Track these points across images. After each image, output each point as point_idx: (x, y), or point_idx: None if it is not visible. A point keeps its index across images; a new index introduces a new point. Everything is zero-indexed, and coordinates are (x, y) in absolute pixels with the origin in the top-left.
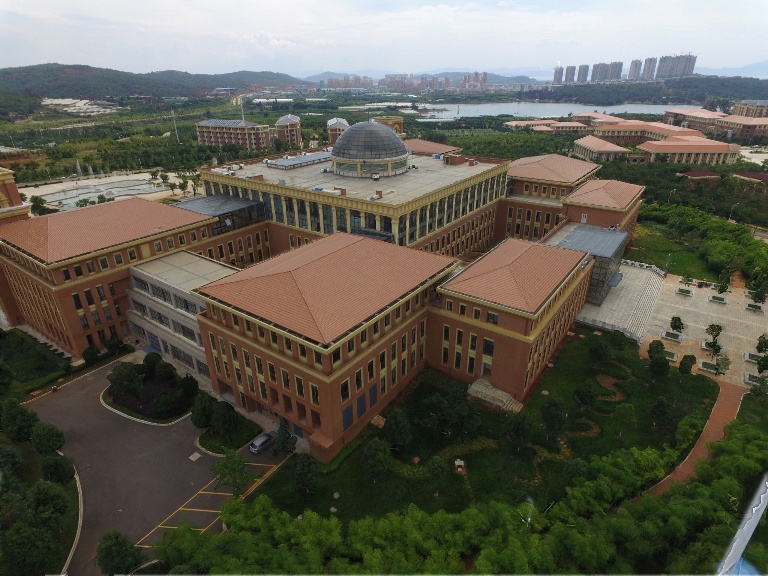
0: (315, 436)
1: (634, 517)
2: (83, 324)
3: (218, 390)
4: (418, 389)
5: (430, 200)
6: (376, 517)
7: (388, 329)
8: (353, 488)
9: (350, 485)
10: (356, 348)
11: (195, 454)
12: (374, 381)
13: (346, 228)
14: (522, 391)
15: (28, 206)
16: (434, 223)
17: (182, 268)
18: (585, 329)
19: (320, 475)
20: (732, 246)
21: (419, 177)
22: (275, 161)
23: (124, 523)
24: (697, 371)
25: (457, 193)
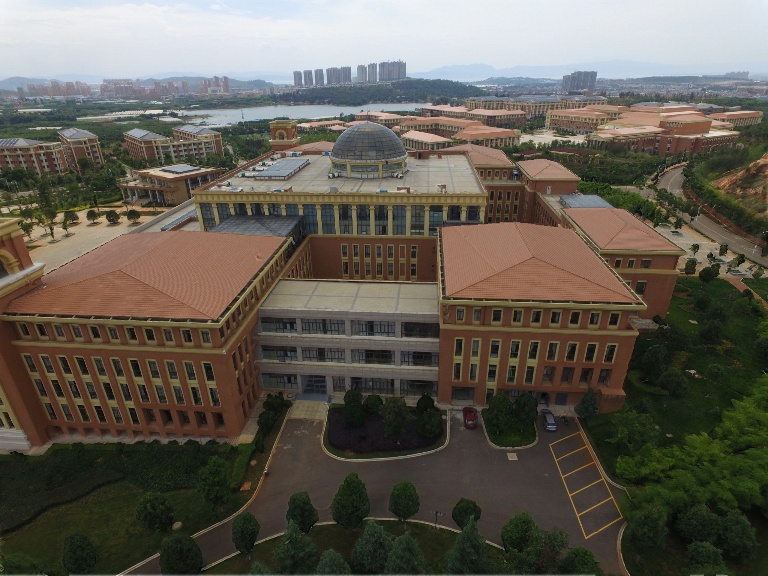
0: (606, 391)
1: None
2: None
3: (449, 399)
4: None
5: None
6: (700, 425)
7: None
8: (660, 416)
9: (656, 416)
10: None
11: (509, 455)
12: None
13: (422, 225)
14: None
15: (43, 266)
16: None
17: (318, 295)
18: None
19: None
20: None
21: (428, 171)
22: (259, 173)
23: (549, 530)
24: None
25: None
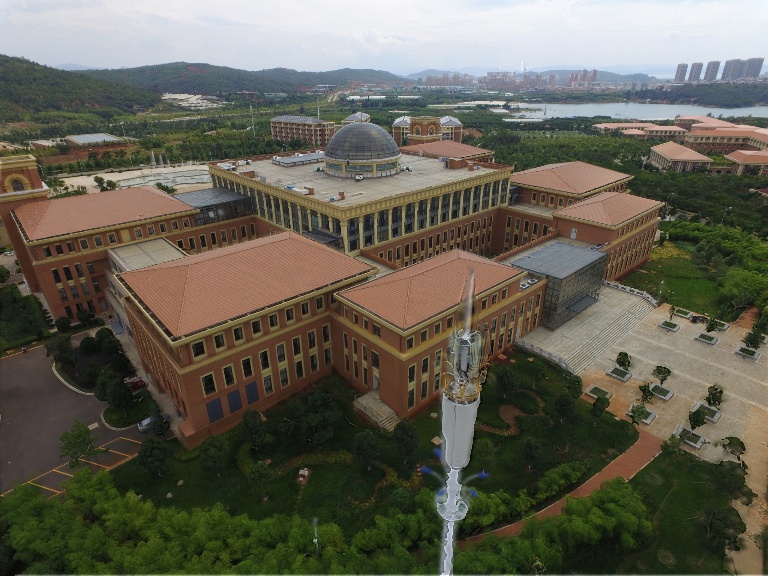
0: (183, 424)
1: (421, 560)
2: (62, 296)
3: (144, 369)
4: (313, 393)
5: (392, 204)
6: None
7: (274, 330)
8: (197, 479)
9: (196, 475)
10: (227, 345)
11: (95, 424)
12: (252, 379)
13: (309, 227)
14: (403, 410)
15: (47, 190)
16: (400, 228)
17: (149, 254)
18: (521, 354)
19: (179, 461)
20: (756, 278)
21: (403, 180)
22: (281, 158)
23: (5, 474)
24: (624, 416)
25: (434, 198)
